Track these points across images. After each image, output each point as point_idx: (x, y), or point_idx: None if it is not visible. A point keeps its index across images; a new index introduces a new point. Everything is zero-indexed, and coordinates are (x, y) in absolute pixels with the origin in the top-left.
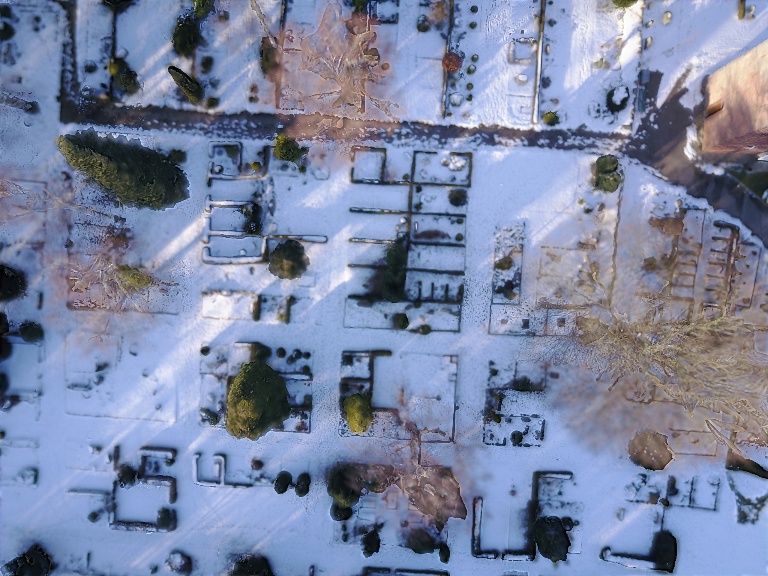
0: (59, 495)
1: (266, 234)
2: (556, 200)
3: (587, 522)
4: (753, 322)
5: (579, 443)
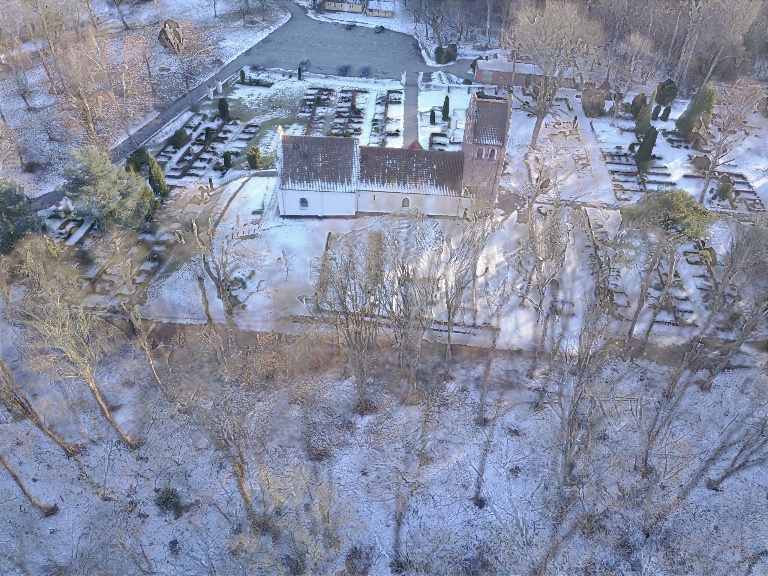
0: (765, 129)
1: (717, 180)
2: (564, 184)
3: (515, 107)
4: (448, 148)
5: (526, 123)
